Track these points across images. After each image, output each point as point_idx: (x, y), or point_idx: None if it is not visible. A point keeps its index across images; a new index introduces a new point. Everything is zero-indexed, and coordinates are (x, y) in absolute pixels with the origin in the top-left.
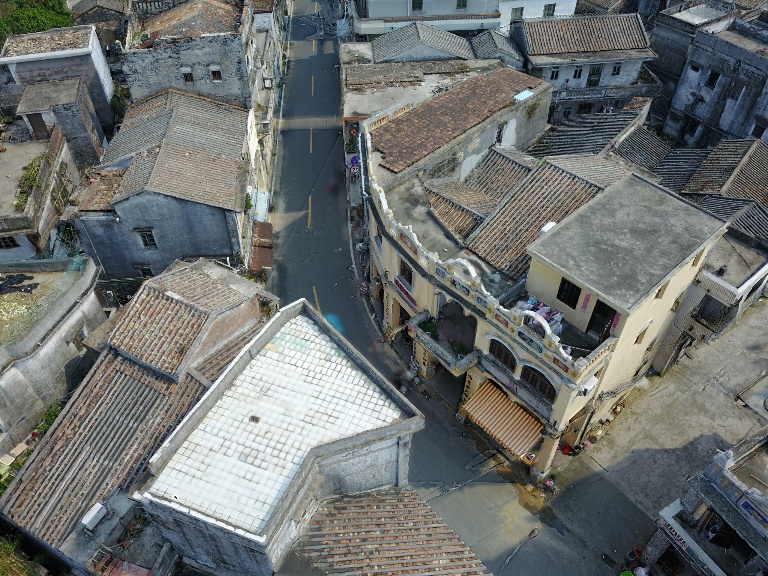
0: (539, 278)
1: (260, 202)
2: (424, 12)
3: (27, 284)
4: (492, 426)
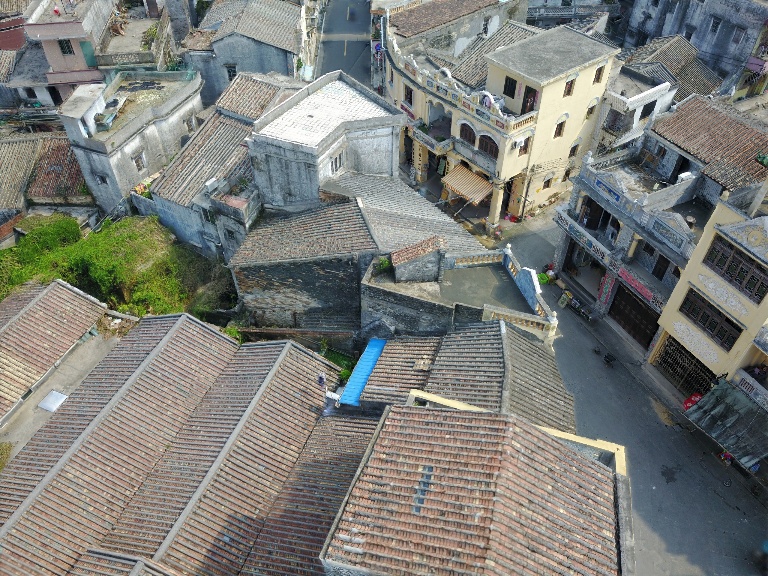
0: (493, 82)
1: (307, 71)
2: None
3: (157, 86)
4: (460, 188)
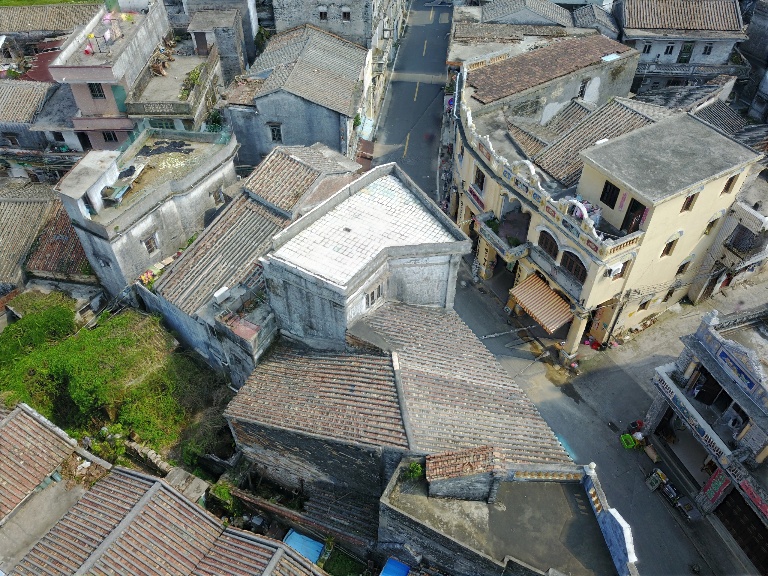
0: (588, 183)
1: (367, 126)
2: None
3: (186, 148)
4: (532, 307)
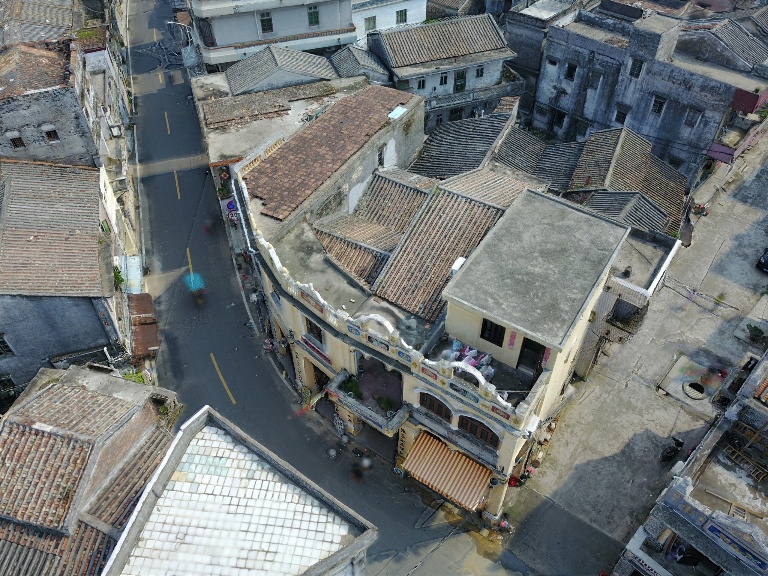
0: (459, 319)
1: (131, 270)
2: (276, 33)
3: None
4: (437, 481)
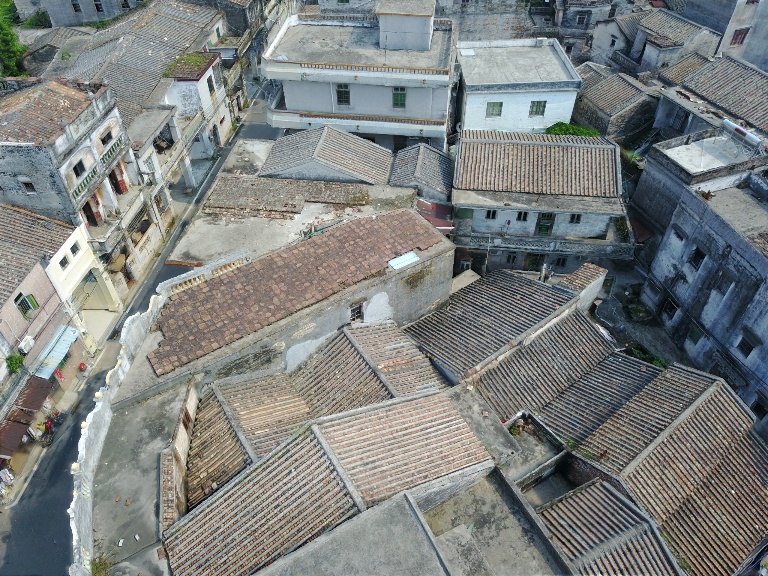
0: None
1: (61, 346)
2: (353, 108)
3: None
4: None
